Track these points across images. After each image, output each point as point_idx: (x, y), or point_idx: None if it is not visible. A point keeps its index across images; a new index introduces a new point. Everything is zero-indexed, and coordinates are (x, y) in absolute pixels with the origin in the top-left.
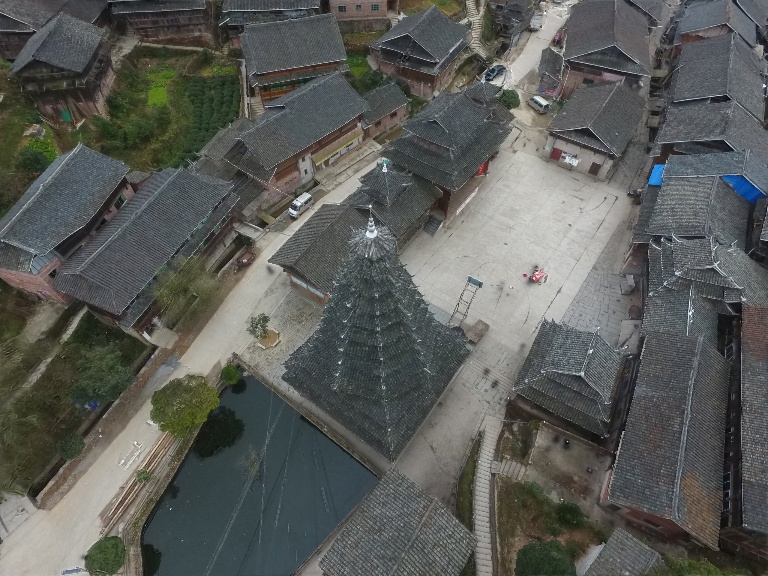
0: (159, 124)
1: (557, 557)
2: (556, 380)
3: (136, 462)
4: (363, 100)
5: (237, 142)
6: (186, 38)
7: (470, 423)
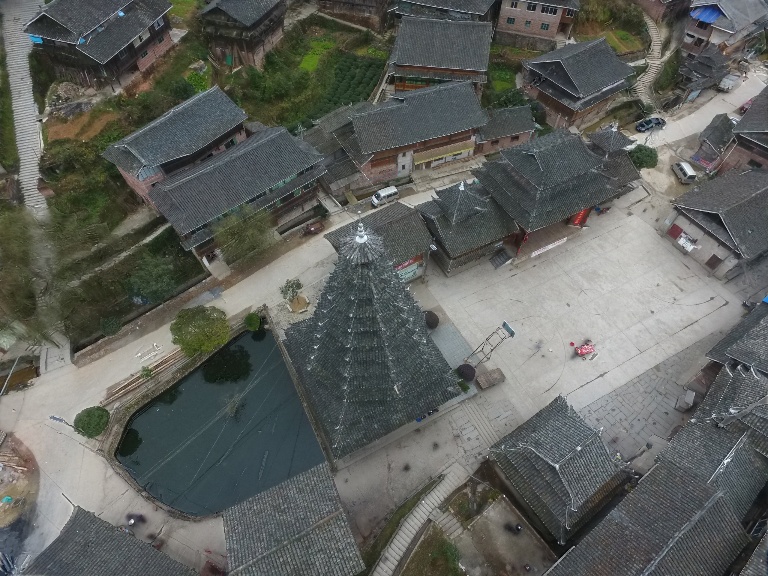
0: (297, 87)
1: None
2: (531, 460)
3: (151, 360)
4: None
5: None
6: (356, 16)
7: (437, 462)
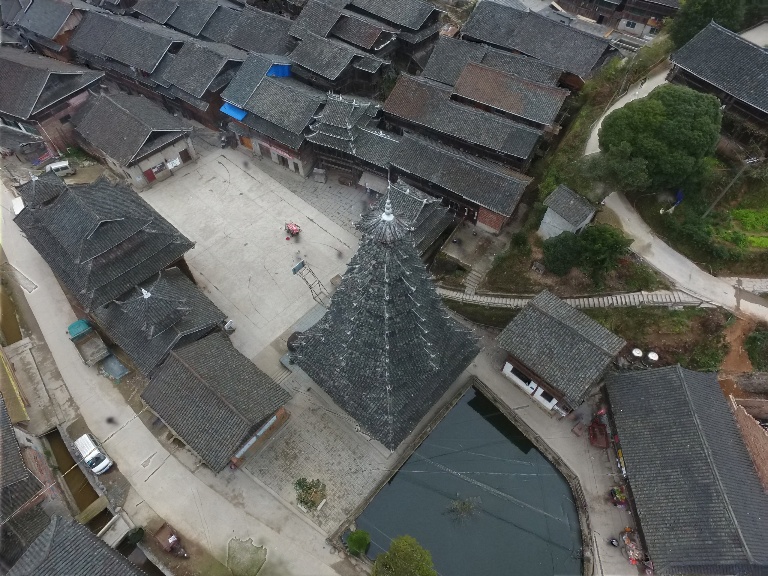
0: None
1: (564, 235)
2: None
3: None
4: None
5: None
6: None
7: None
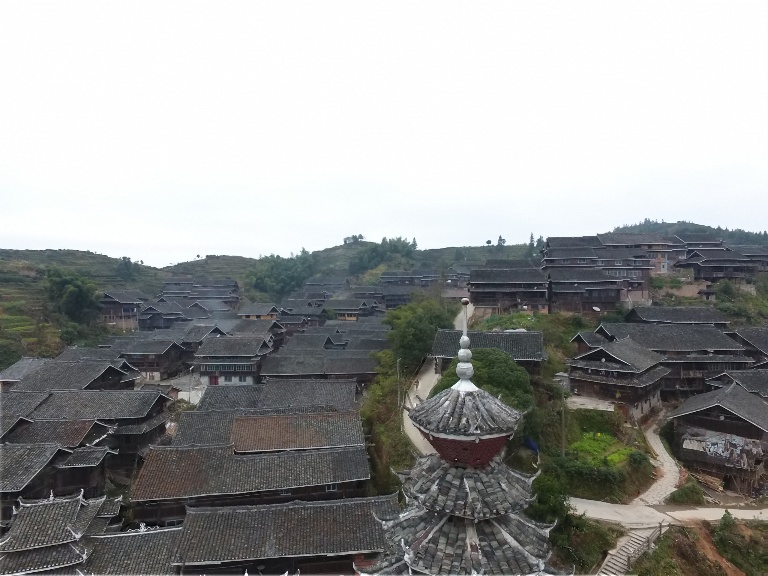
0: None
1: None
2: None
3: None
4: None
5: None
6: None
7: None
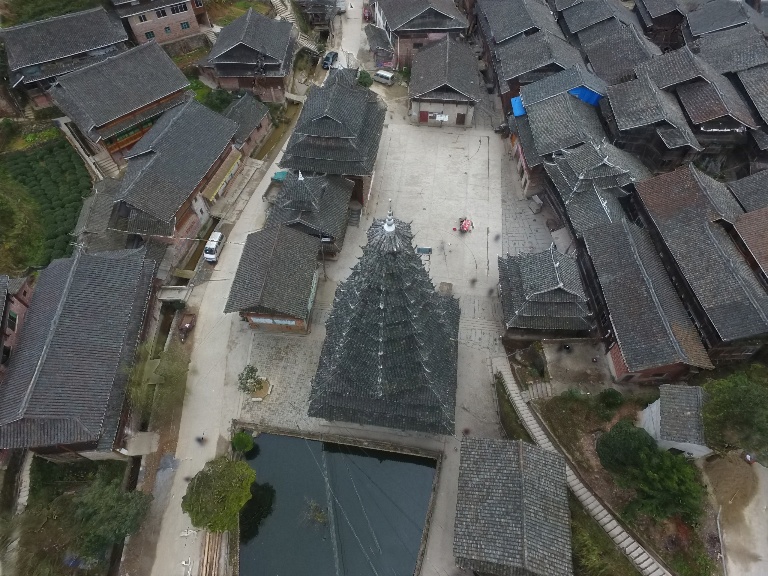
0: None
1: (636, 431)
2: (540, 300)
3: None
4: (230, 120)
5: (112, 206)
6: None
7: (483, 372)
